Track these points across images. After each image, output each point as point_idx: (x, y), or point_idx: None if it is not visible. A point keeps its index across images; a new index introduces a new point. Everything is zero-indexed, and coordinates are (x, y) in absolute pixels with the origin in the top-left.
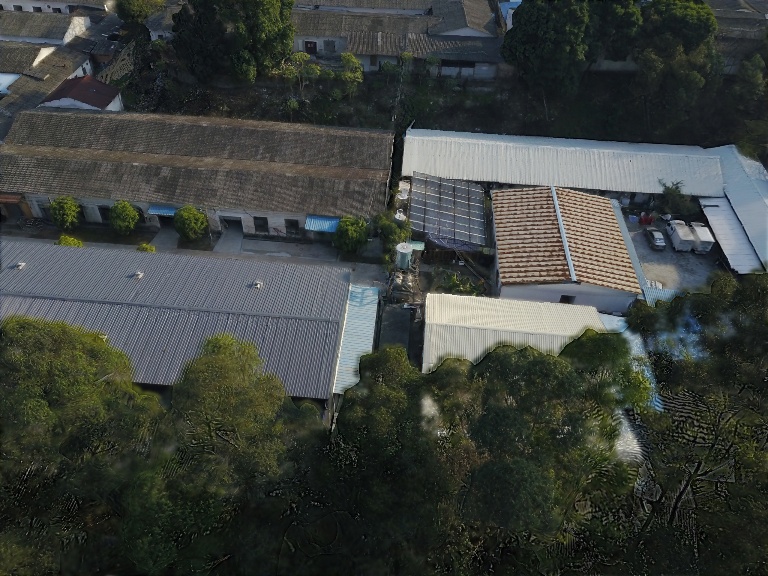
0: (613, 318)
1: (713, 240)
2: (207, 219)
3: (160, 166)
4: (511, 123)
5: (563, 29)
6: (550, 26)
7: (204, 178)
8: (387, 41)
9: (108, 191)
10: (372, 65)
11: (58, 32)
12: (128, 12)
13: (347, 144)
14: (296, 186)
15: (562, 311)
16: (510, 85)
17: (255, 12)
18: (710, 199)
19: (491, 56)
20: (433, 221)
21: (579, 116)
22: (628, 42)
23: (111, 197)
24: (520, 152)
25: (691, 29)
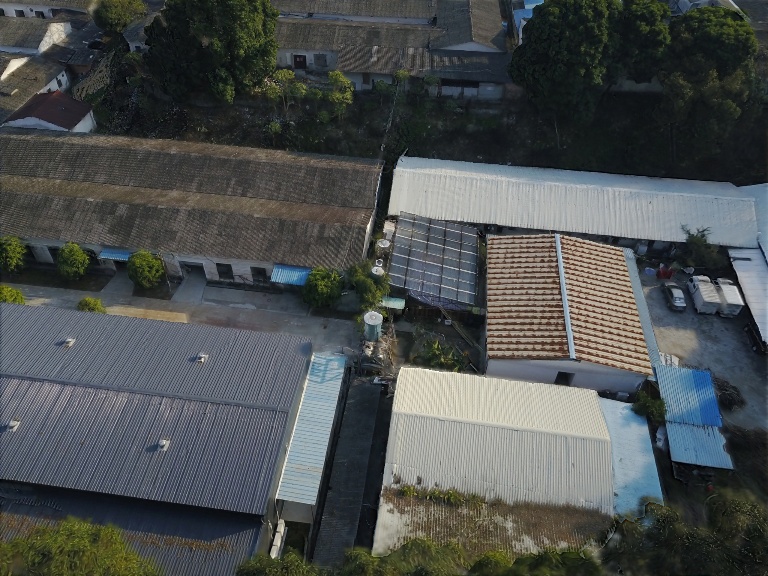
0: (617, 404)
1: (742, 303)
2: (163, 266)
3: (116, 203)
4: (518, 151)
5: (577, 49)
6: (563, 45)
7: (163, 218)
8: (382, 56)
9: (57, 231)
10: (365, 83)
11: (33, 40)
12: (105, 20)
13: (328, 178)
14: (264, 229)
15: (556, 396)
16: (518, 107)
17: (232, 26)
18: (741, 250)
19: (497, 75)
20: (416, 274)
21: (595, 144)
22: (653, 63)
23: (60, 238)
24: (523, 189)
25: (727, 50)
